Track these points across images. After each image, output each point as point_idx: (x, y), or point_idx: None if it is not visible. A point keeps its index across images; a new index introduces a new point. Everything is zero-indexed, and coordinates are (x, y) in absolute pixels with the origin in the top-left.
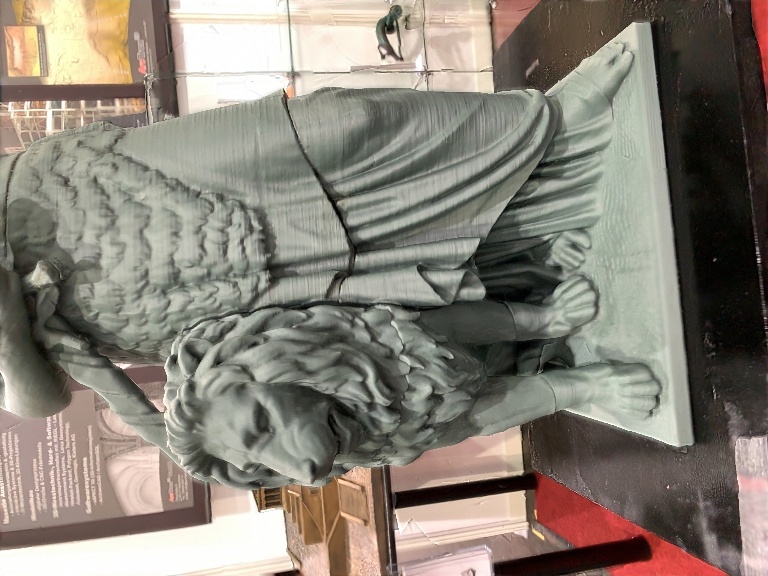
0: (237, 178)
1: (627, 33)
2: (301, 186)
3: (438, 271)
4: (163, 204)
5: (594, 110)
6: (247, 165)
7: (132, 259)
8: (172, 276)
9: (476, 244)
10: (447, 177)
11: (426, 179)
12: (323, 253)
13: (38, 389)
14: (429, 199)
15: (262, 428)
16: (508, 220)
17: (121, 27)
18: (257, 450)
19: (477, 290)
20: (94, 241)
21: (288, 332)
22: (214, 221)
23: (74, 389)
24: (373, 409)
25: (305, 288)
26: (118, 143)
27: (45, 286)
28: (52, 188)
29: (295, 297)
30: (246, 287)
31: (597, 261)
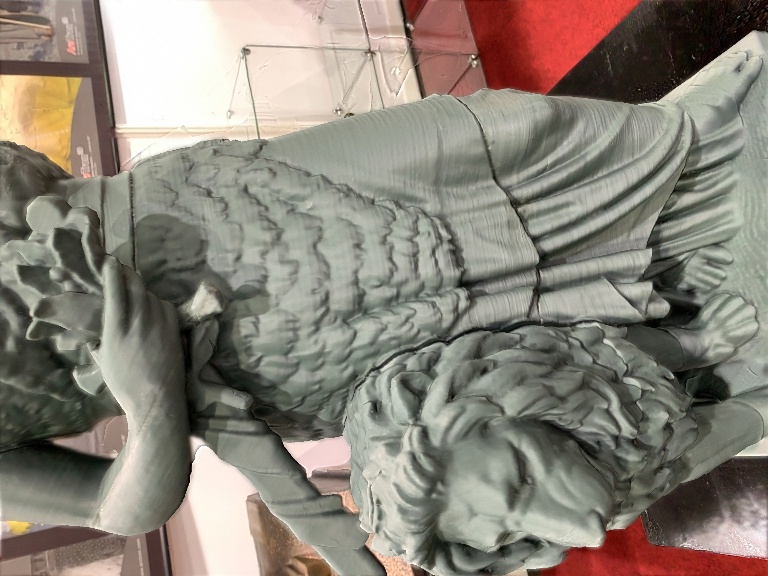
0: (416, 181)
1: (746, 42)
2: (481, 191)
3: (625, 284)
4: (337, 212)
5: (725, 117)
6: (429, 164)
7: (309, 280)
8: (357, 299)
9: (650, 254)
10: (618, 180)
11: (599, 183)
12: (514, 266)
13: (174, 476)
14: (603, 205)
15: (522, 478)
16: (654, 236)
17: (62, 142)
18: (521, 510)
19: (661, 305)
20: (258, 260)
21: (519, 352)
22: (400, 229)
23: (4, 559)
24: (617, 445)
25: (506, 306)
26: (264, 150)
27: (207, 318)
28: (194, 200)
29: (496, 318)
30: (447, 307)
31: (745, 274)
